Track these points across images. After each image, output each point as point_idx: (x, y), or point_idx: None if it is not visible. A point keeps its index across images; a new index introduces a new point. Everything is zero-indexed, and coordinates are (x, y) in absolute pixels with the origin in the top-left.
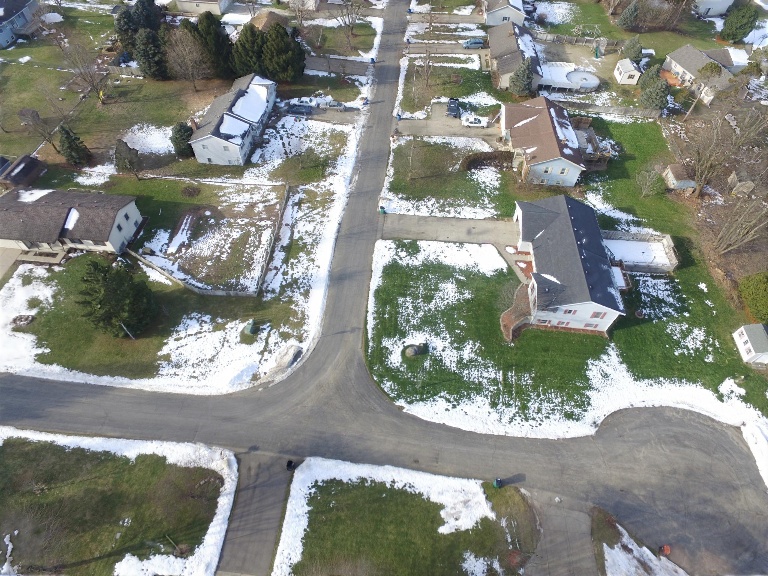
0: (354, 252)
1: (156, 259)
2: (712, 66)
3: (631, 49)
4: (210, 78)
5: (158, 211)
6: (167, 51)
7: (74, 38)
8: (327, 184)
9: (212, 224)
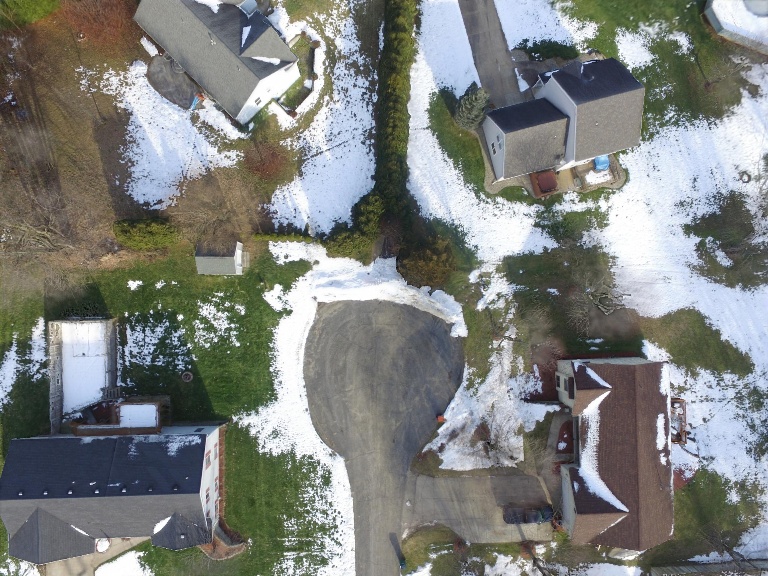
0: None
1: None
2: None
3: None
4: None
5: None
6: None
7: None
8: None
9: None
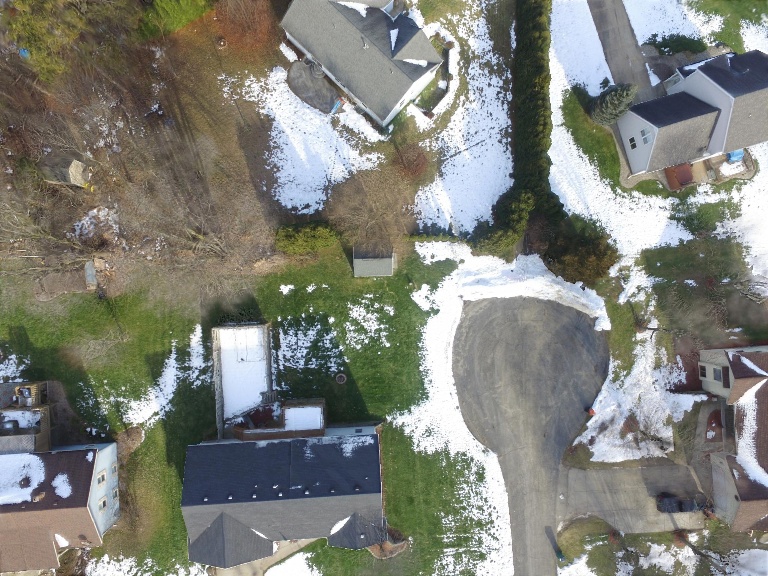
0: None
1: None
2: None
3: None
4: None
5: None
6: None
7: None
8: None
9: None
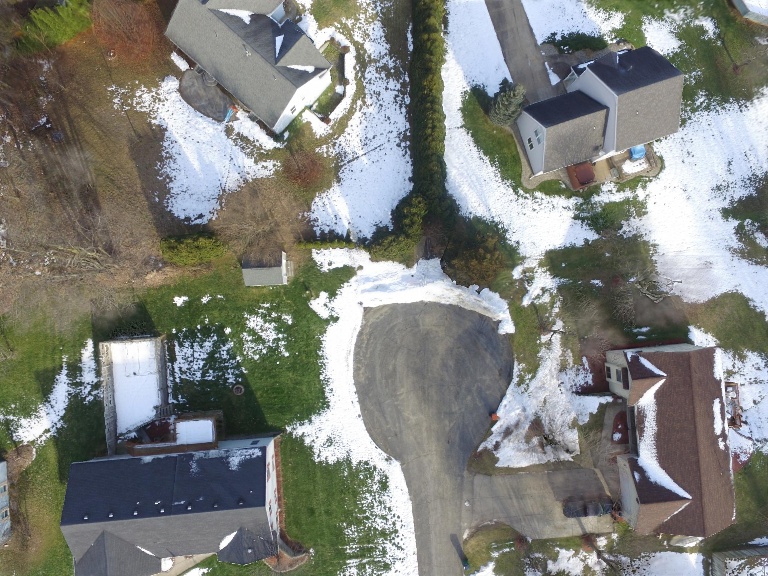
0: None
1: None
2: None
3: None
4: None
5: None
6: None
7: None
8: None
9: None
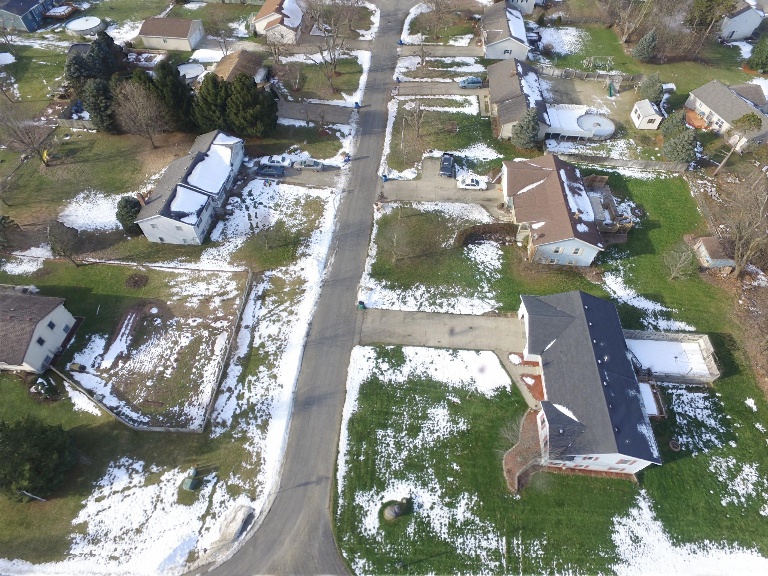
0: (325, 364)
1: (86, 378)
2: (750, 119)
3: (650, 88)
4: (171, 131)
5: (95, 309)
6: (120, 104)
7: (25, 83)
8: (297, 269)
9: (158, 326)
